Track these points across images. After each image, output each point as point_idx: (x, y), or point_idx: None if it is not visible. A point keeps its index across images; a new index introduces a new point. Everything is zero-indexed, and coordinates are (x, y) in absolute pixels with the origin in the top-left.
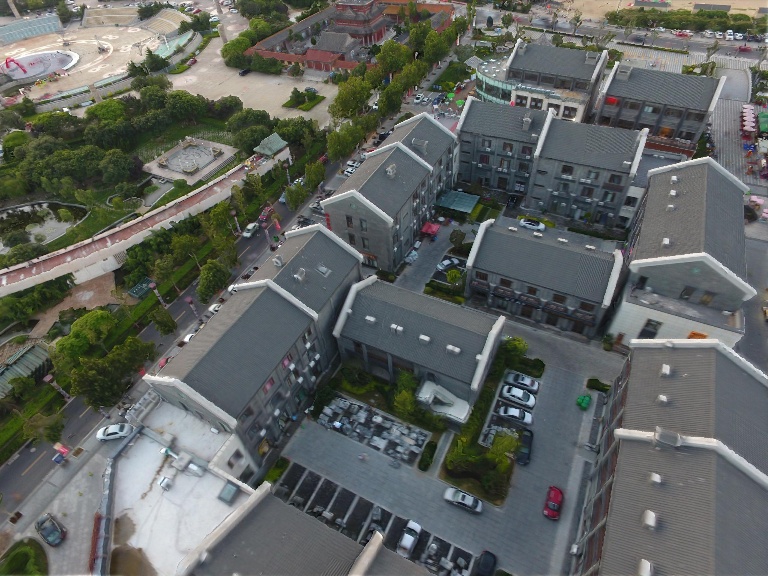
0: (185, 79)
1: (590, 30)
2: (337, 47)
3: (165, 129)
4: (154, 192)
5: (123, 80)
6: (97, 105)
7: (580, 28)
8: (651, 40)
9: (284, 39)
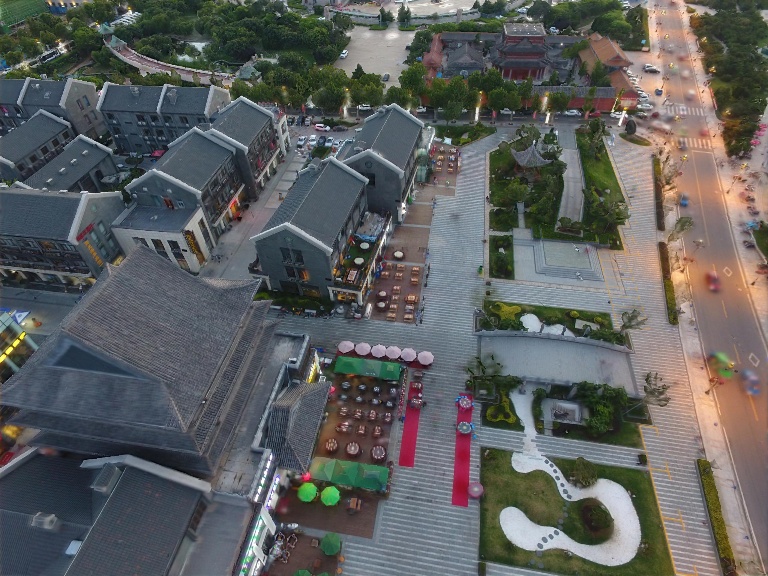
0: (392, 35)
1: (707, 216)
2: (453, 60)
3: (291, 46)
4: (228, 69)
5: (372, 18)
6: (305, 18)
7: (715, 208)
8: (717, 282)
9: (470, 40)
